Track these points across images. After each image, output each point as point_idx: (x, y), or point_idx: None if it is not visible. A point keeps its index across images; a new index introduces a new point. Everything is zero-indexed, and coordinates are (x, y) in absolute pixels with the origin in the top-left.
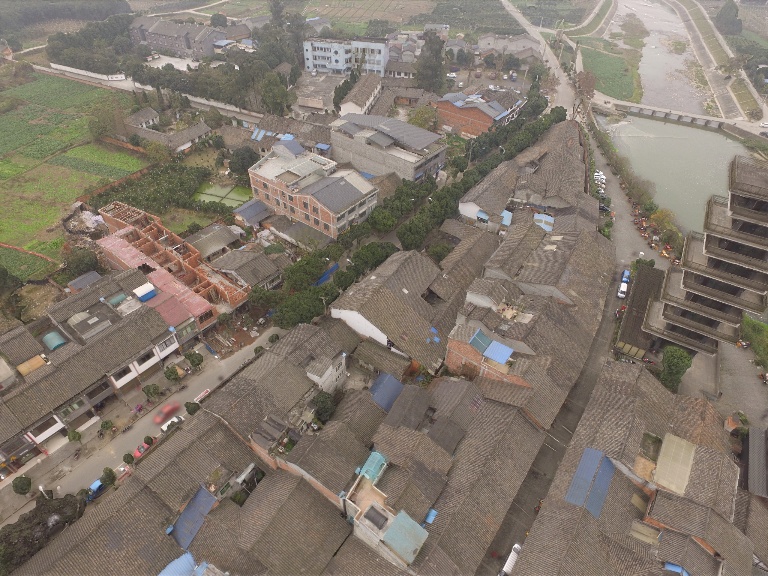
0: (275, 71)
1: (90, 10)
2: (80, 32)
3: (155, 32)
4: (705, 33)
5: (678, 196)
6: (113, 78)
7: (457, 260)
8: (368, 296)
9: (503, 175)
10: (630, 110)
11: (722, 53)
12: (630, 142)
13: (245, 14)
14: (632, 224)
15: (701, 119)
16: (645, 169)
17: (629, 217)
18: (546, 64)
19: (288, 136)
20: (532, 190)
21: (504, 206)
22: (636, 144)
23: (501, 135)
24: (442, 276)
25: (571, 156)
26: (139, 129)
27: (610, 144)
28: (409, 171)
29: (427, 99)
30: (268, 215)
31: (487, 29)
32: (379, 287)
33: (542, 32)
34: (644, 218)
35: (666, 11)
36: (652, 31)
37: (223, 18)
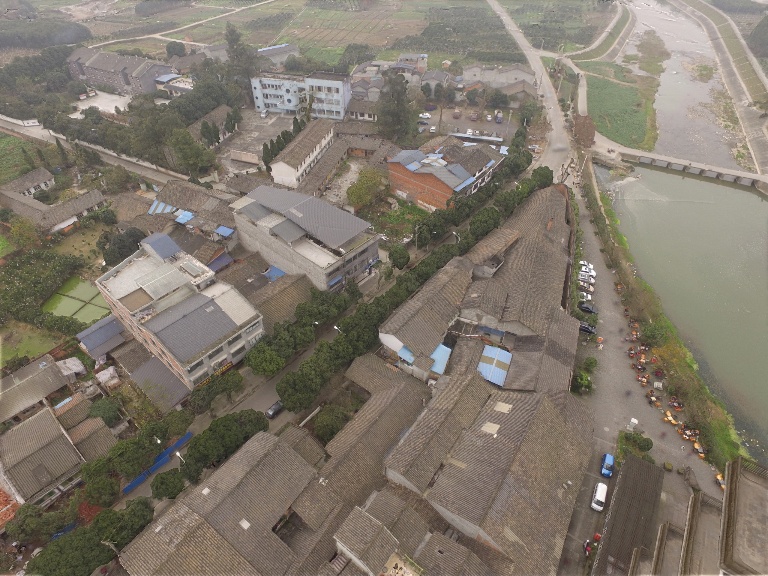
0: (207, 117)
1: (40, 38)
2: (5, 68)
3: (92, 66)
4: (736, 55)
5: (695, 297)
6: (30, 123)
7: (349, 446)
8: (172, 548)
9: (447, 285)
10: (639, 161)
11: (757, 82)
12: (636, 209)
13: (215, 38)
14: (626, 357)
15: (729, 175)
16: (653, 252)
17: (623, 343)
18: (541, 99)
19: (186, 215)
20: (483, 311)
21: (440, 338)
22: (644, 212)
23: (461, 211)
24: (318, 481)
25: (549, 246)
26: (14, 201)
27: (610, 212)
28: (320, 277)
29: (383, 153)
30: (122, 342)
31: (479, 54)
32: (196, 527)
33: (543, 57)
34: (643, 347)
35: (691, 27)
36: (674, 52)
37: (180, 46)
